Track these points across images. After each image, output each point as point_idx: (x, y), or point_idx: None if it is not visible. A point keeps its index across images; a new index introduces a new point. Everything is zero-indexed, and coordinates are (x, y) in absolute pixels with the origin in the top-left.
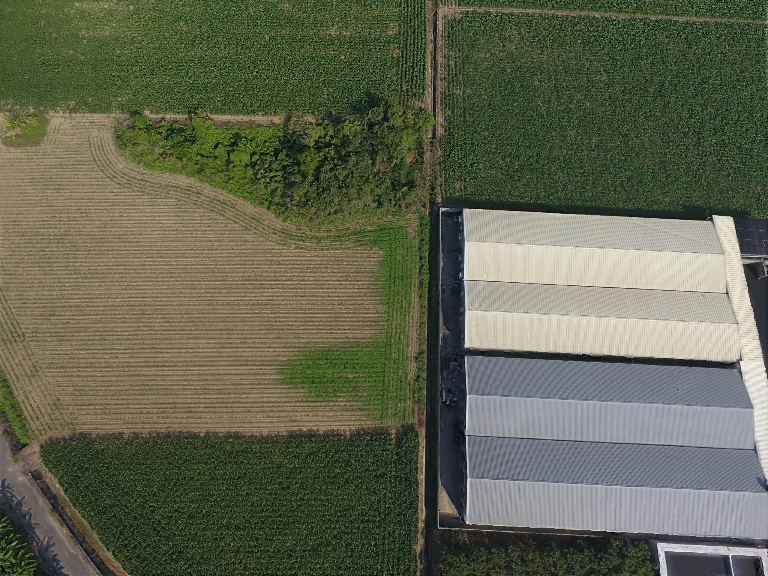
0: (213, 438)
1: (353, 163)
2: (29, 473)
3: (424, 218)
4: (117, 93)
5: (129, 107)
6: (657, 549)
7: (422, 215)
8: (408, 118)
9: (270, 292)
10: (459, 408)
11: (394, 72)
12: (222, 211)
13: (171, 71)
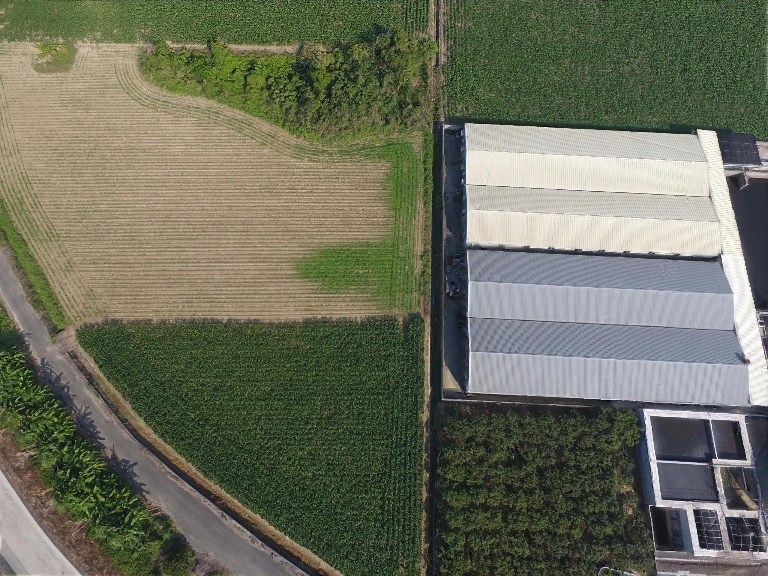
0: (235, 324)
1: (362, 85)
2: (66, 353)
3: (428, 135)
4: (140, 25)
5: (152, 37)
6: (643, 414)
7: (426, 132)
8: (413, 44)
9: (286, 199)
10: (461, 297)
11: (399, 7)
12: (240, 129)
13: (191, 5)
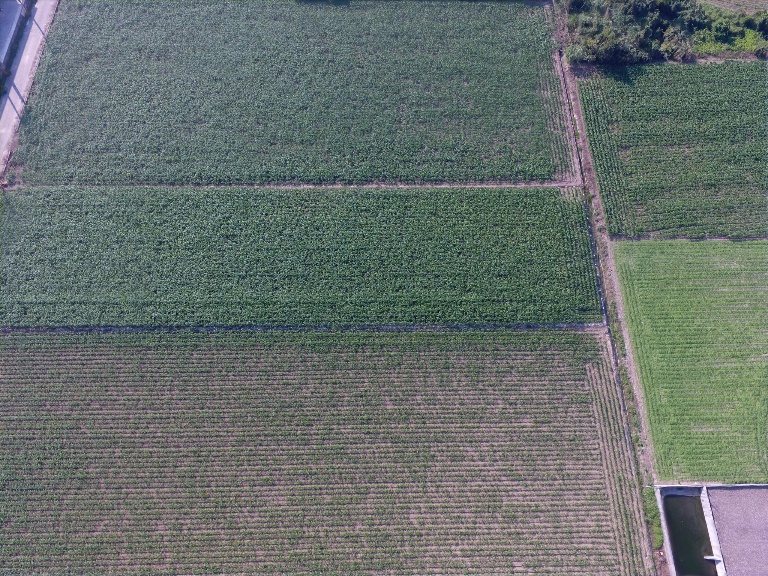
0: None
1: None
2: None
3: None
4: None
5: None
6: None
7: None
8: None
9: None
10: None
11: None
12: None
13: None
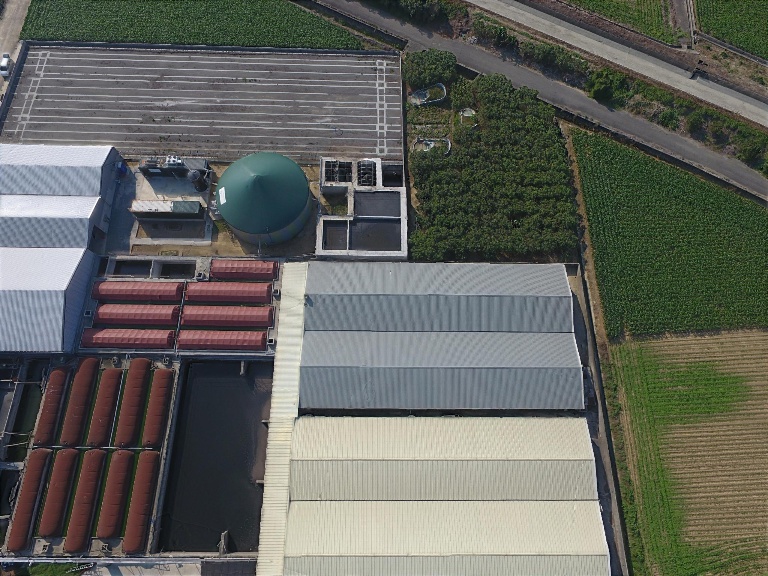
0: None
1: None
2: None
3: None
4: None
5: None
6: None
7: None
8: None
9: None
10: None
11: None
12: None
13: None
